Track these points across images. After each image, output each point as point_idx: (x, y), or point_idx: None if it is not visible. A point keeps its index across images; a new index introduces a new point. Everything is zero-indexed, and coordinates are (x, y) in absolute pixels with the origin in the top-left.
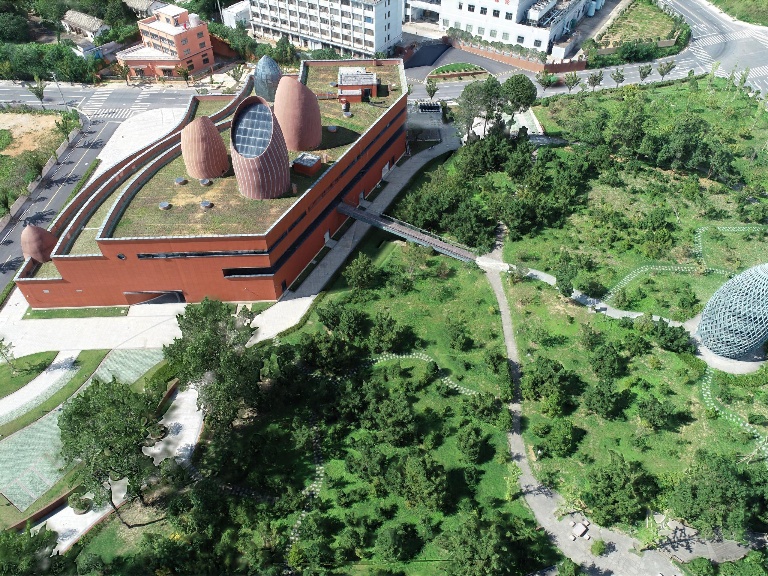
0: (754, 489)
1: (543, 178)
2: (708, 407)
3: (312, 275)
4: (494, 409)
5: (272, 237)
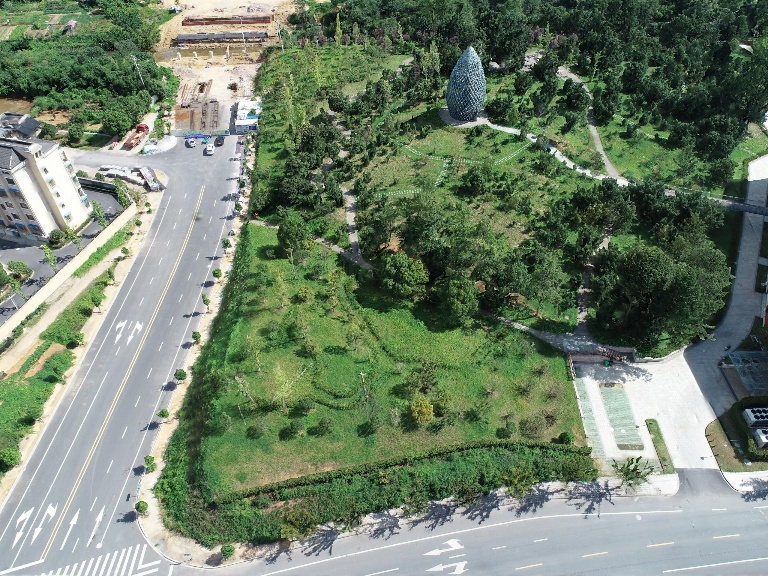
0: (500, 40)
1: None
2: (487, 94)
3: (765, 194)
4: (605, 95)
5: None
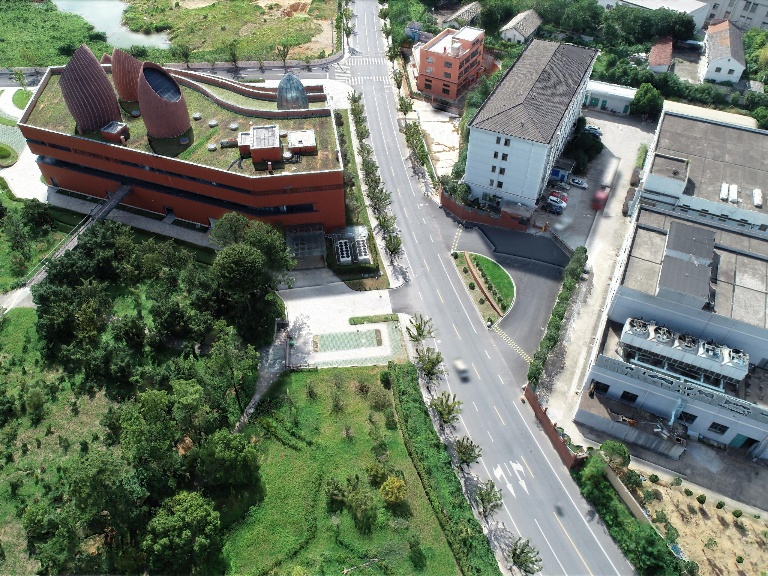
0: None
1: (124, 333)
2: None
3: (73, 199)
4: None
5: (28, 132)
